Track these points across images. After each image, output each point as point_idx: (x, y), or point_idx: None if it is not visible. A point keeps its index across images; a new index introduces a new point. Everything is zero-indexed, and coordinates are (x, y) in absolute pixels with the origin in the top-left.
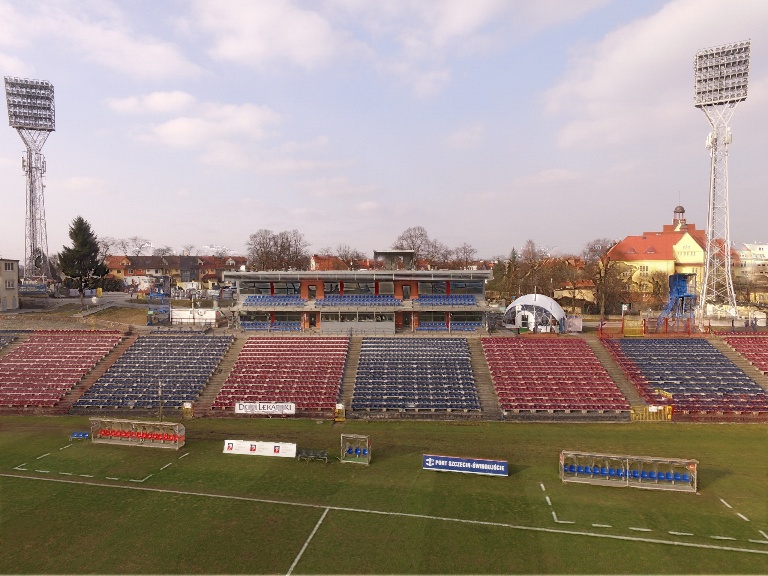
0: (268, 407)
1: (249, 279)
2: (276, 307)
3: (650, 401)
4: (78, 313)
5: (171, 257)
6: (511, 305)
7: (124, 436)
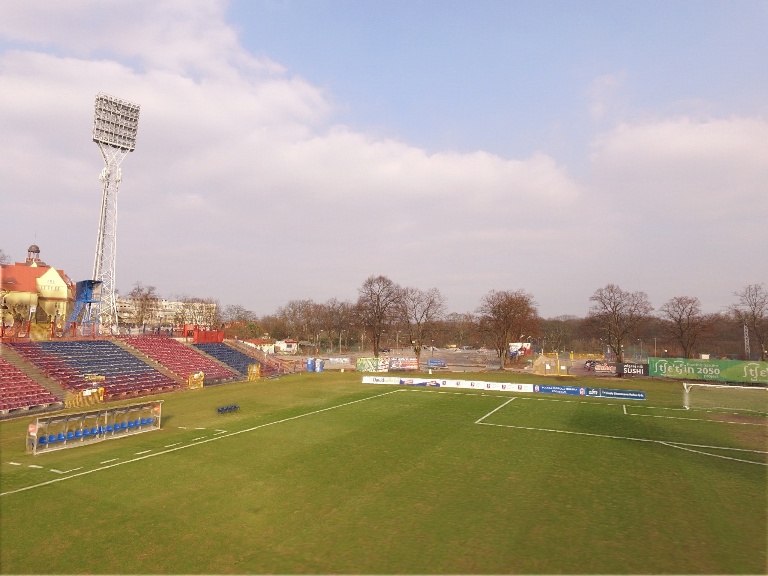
0: None
1: None
2: None
3: (76, 392)
4: None
5: None
6: None
7: None
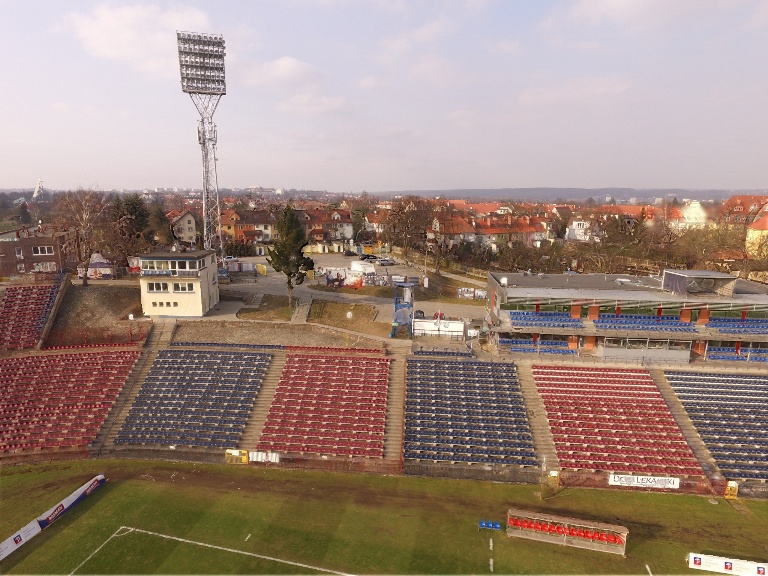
0: (647, 480)
1: (536, 302)
2: (550, 328)
3: None
4: (295, 313)
5: (278, 211)
6: None
7: (543, 530)
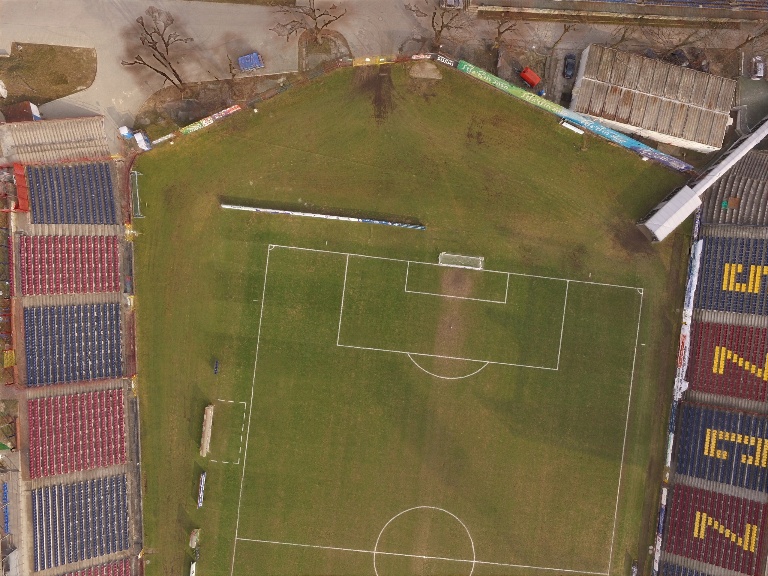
0: None
1: None
2: None
3: (112, 377)
4: None
5: None
6: None
7: None
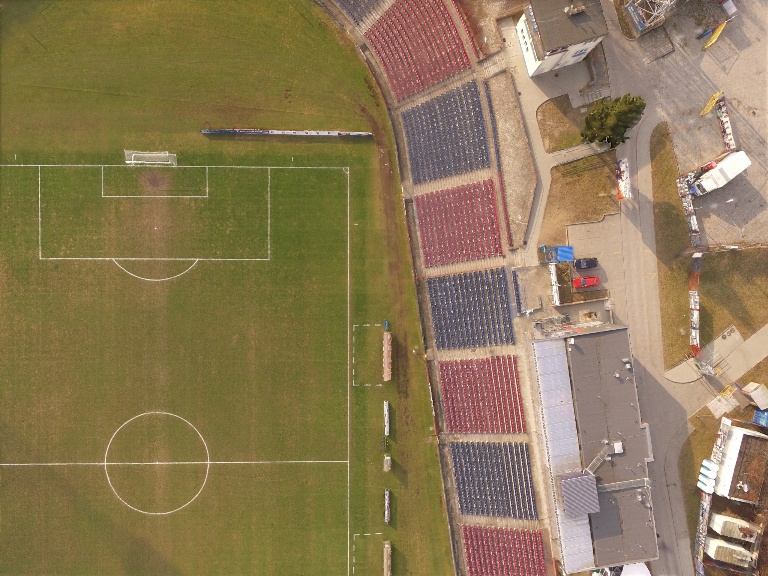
0: None
1: None
2: None
3: None
4: (566, 150)
5: None
6: (627, 571)
7: None
